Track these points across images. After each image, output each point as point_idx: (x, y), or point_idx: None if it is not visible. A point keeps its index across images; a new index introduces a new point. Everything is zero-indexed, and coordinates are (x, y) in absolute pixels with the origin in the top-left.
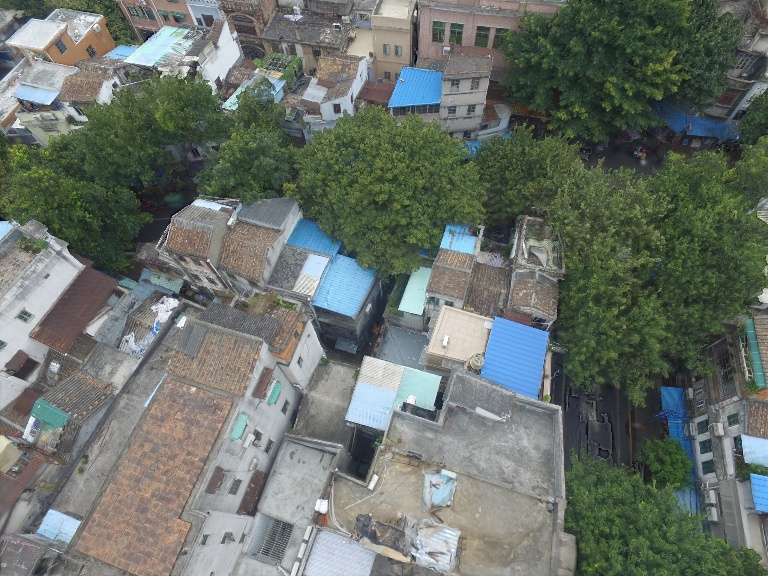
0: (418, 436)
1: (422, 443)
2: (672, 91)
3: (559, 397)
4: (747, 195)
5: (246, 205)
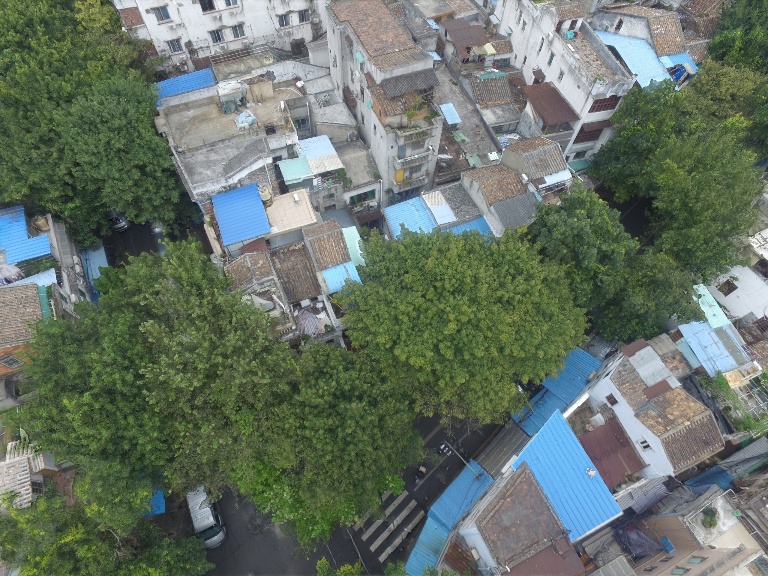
0: None
1: None
2: None
3: None
4: None
5: None
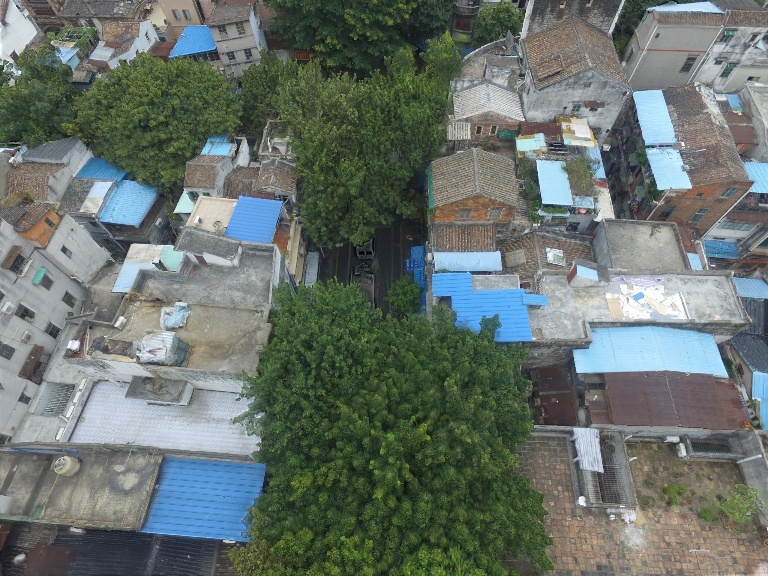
0: (166, 289)
1: (169, 293)
2: (405, 18)
3: (345, 277)
4: (440, 81)
5: (31, 148)
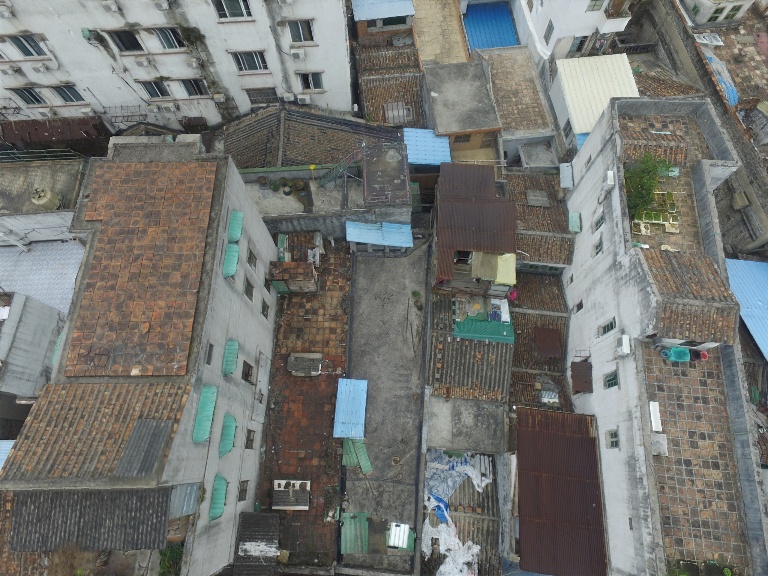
0: None
1: None
2: None
3: None
4: None
5: None
